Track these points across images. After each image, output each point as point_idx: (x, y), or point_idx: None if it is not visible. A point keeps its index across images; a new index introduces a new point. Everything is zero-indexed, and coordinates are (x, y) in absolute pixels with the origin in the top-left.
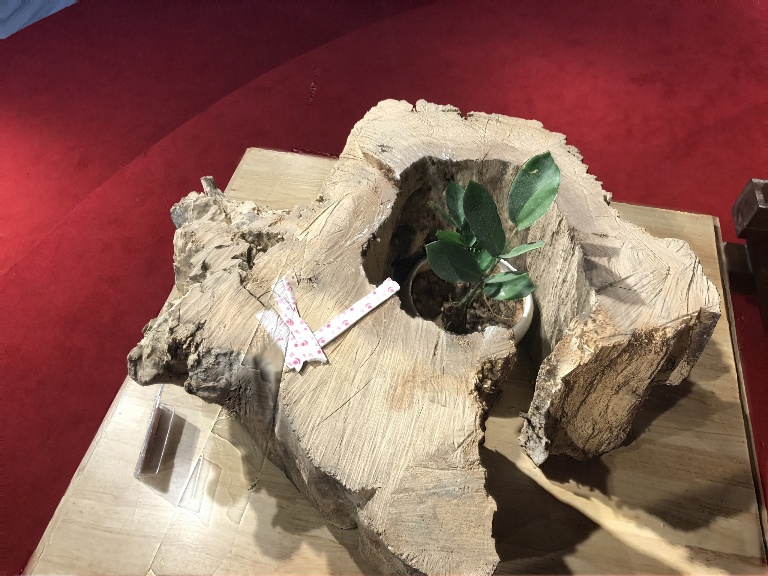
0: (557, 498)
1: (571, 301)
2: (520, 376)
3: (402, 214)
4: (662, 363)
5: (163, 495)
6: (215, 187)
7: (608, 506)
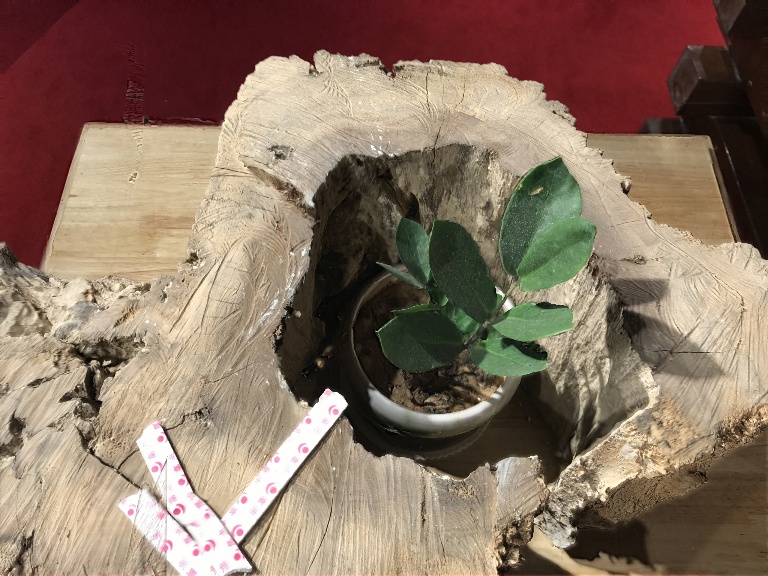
0: None
1: (596, 355)
2: (511, 412)
3: (323, 239)
4: None
5: None
6: (14, 261)
7: None
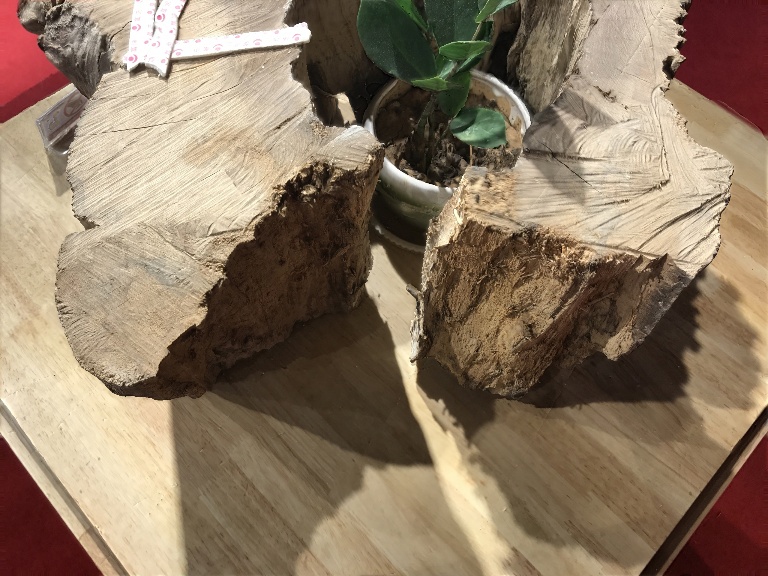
0: (410, 407)
1: None
2: None
3: None
4: (570, 302)
5: (55, 175)
6: None
7: (460, 451)
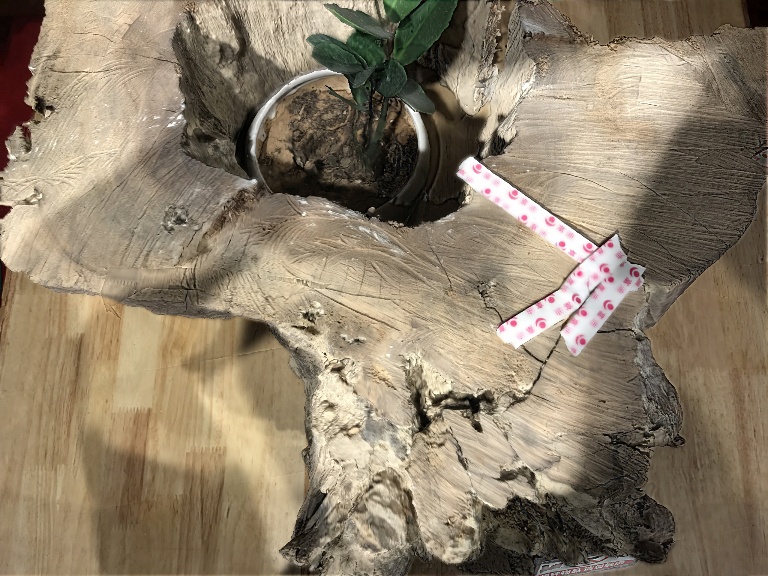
0: None
1: None
2: None
3: None
4: None
5: None
6: None
7: None
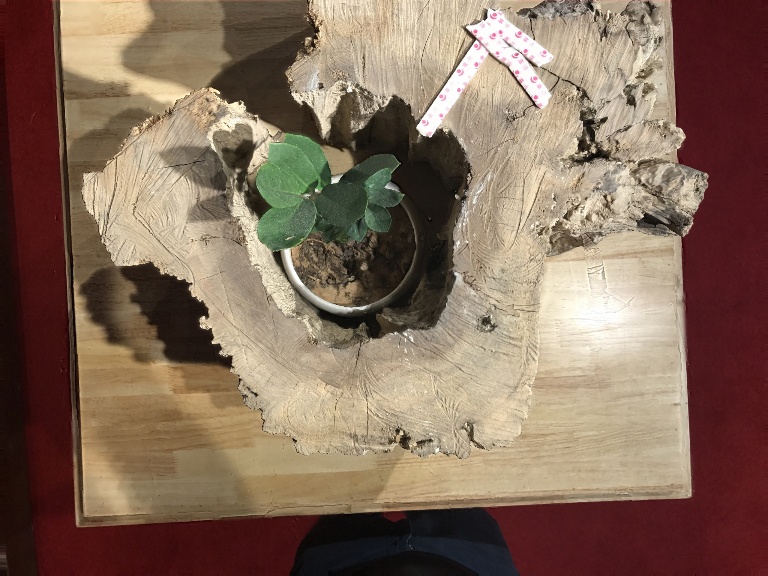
0: None
1: None
2: None
3: None
4: None
5: None
6: (673, 226)
7: None
